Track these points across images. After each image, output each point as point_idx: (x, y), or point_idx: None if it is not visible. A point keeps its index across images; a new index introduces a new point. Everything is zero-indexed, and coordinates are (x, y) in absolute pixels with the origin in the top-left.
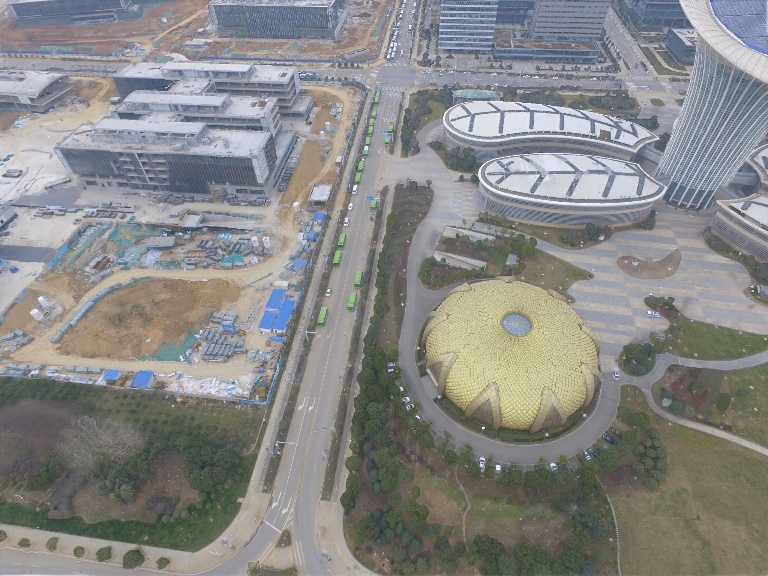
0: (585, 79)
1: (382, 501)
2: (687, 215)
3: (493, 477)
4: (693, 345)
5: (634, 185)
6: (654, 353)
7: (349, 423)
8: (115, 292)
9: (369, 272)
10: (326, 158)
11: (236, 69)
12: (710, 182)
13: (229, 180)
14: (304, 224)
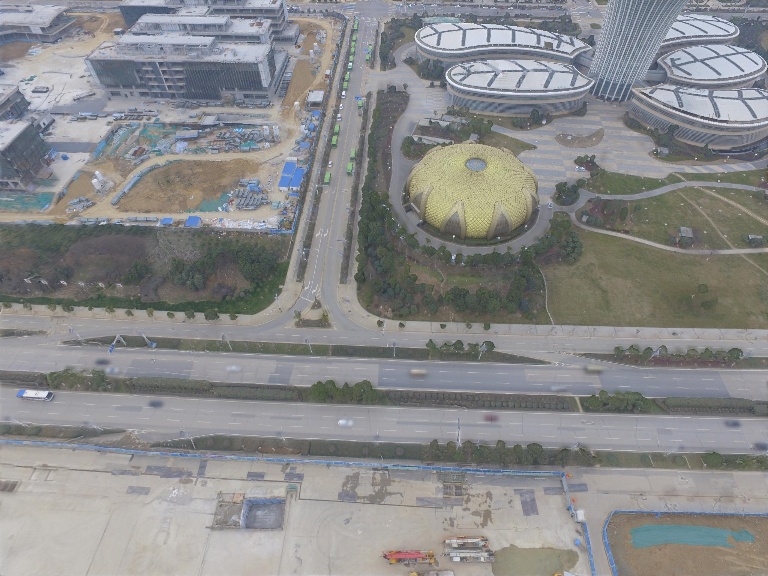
0: (536, 9)
1: (384, 278)
2: (612, 106)
3: (461, 259)
4: (606, 183)
5: (569, 79)
6: (577, 188)
7: (355, 242)
8: (156, 169)
9: (361, 150)
10: (316, 72)
11: None
12: (628, 76)
13: (238, 85)
14: (304, 119)
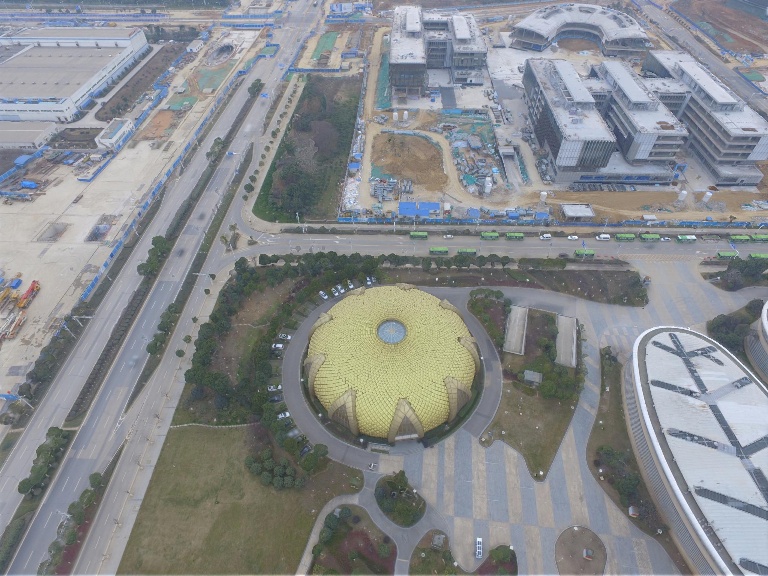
0: None
1: None
2: None
3: None
4: (419, 574)
5: None
6: None
7: None
8: None
9: None
10: (649, 209)
11: (716, 96)
12: None
13: None
14: None
